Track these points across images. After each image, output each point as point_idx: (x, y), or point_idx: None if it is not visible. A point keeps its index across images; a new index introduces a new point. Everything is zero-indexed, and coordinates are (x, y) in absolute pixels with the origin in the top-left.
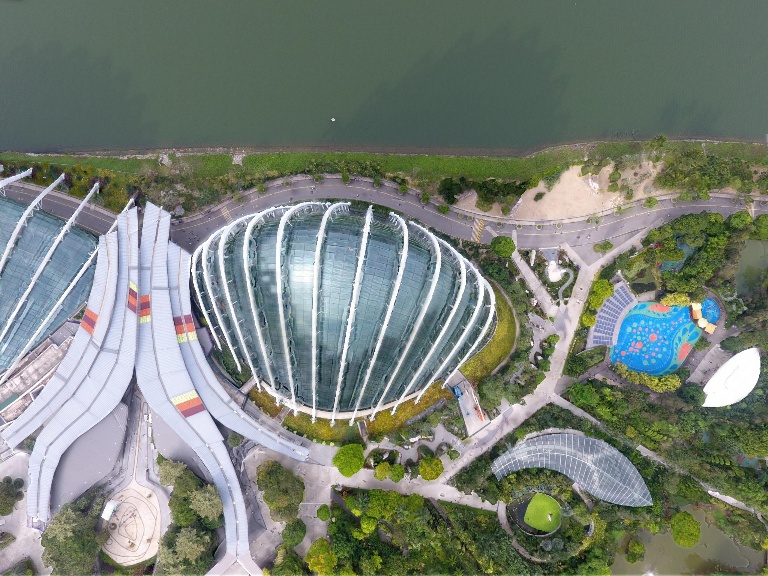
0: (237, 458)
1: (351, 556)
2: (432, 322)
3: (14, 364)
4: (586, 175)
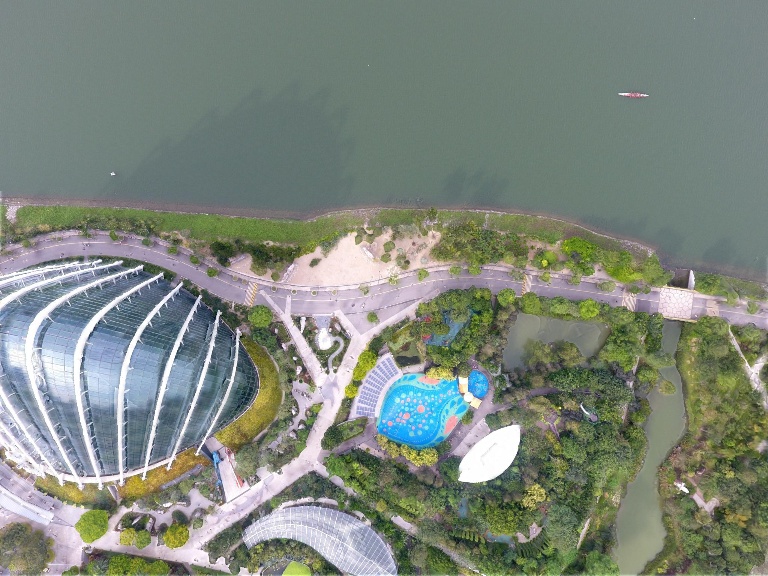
0: None
1: None
2: (145, 402)
3: None
4: (364, 242)
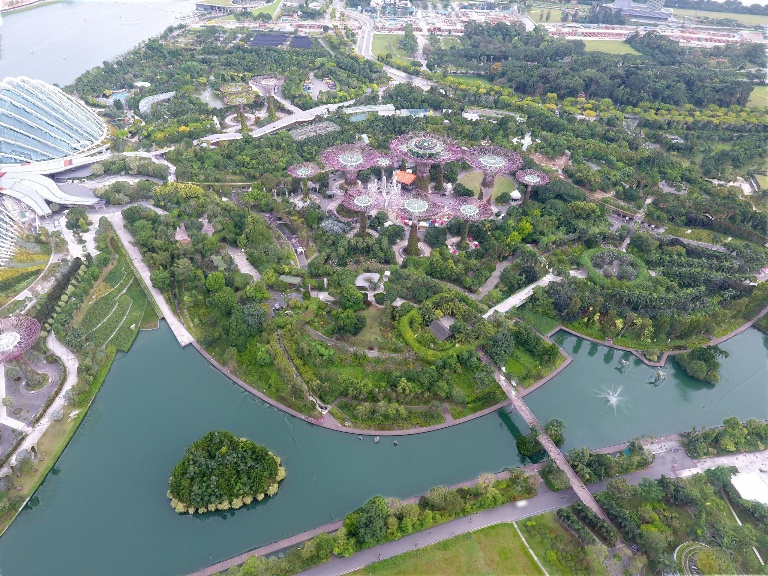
0: None
1: None
2: None
3: (1, 208)
4: None
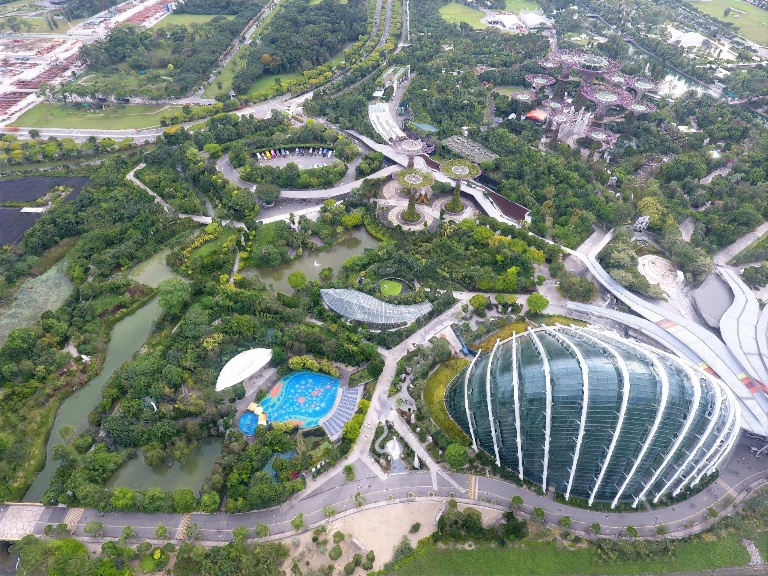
0: (612, 305)
1: (517, 259)
2: None
3: None
4: None
